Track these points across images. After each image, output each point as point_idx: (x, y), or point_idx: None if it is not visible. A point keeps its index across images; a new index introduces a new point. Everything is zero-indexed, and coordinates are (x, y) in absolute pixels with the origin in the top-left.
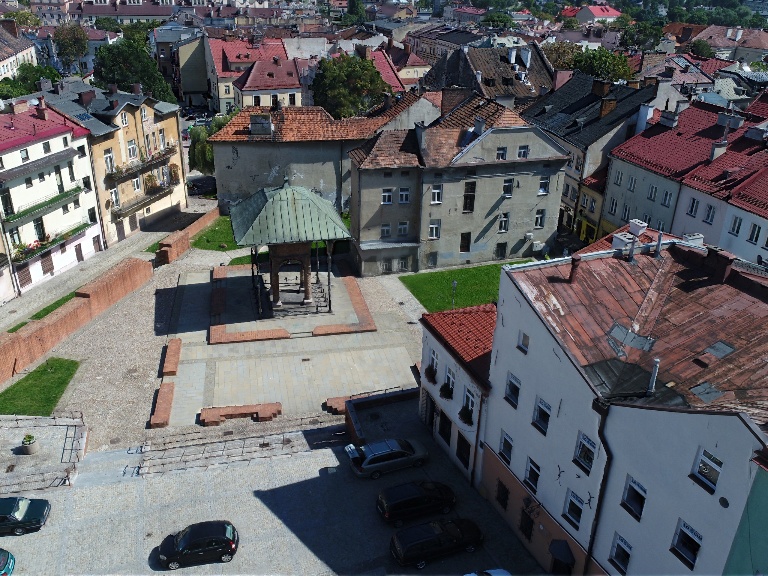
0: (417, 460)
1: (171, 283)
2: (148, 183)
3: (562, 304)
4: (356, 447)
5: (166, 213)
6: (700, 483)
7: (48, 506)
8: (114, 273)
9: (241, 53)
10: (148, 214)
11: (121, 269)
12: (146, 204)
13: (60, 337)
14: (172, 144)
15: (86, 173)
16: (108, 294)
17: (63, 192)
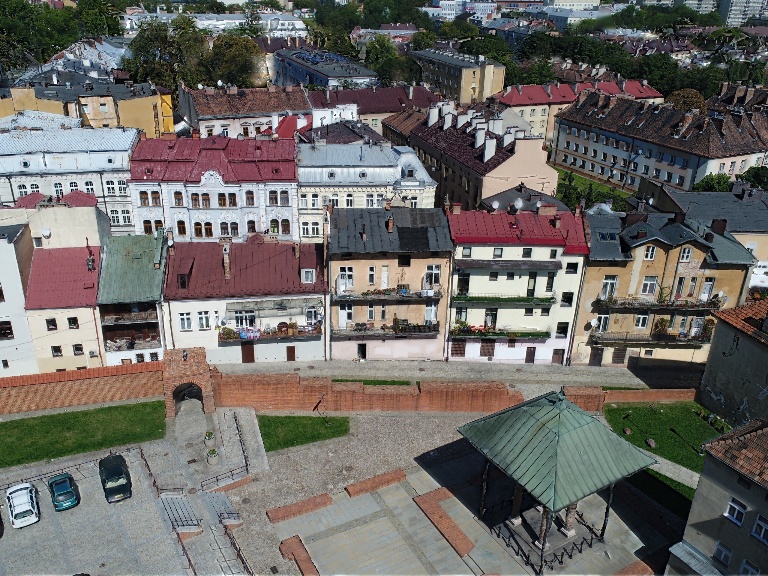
0: None
1: None
2: (660, 326)
3: None
4: None
5: (679, 365)
6: None
7: (127, 495)
8: (467, 386)
9: None
10: (648, 356)
11: (477, 387)
12: (647, 345)
13: (374, 407)
14: (719, 298)
15: (571, 289)
16: (447, 400)
17: (533, 296)
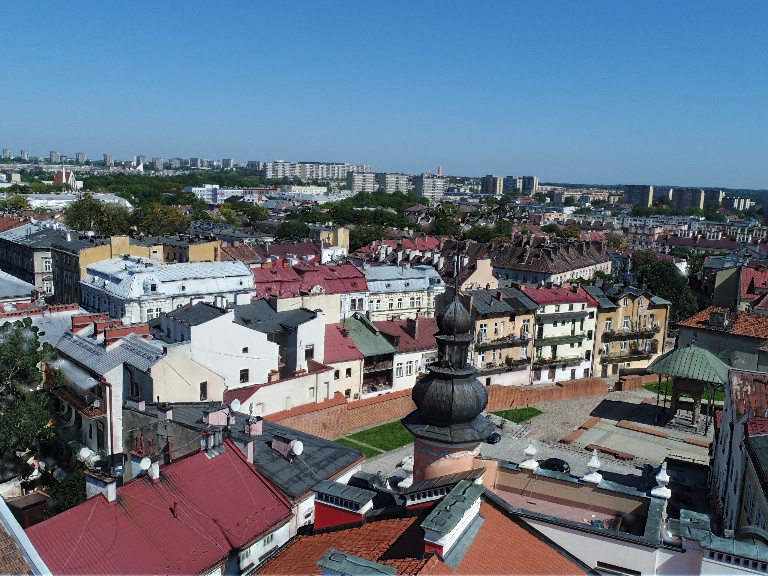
0: (685, 486)
1: (616, 399)
2: (633, 347)
3: (753, 390)
4: None
5: (642, 371)
6: (741, 447)
7: (500, 438)
8: (582, 380)
9: (767, 281)
10: (628, 367)
11: (587, 380)
12: (628, 360)
13: (540, 400)
14: (658, 326)
15: (591, 328)
16: (574, 390)
17: (574, 335)
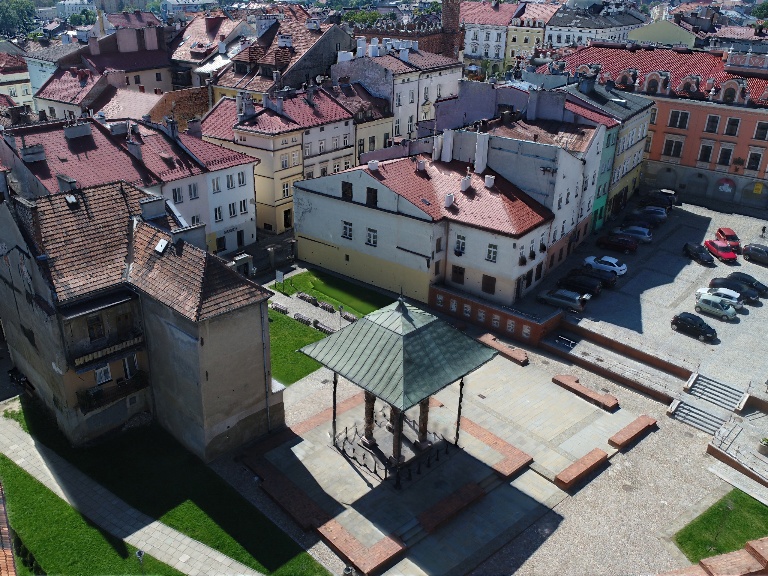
0: None
1: None
2: None
3: None
4: (584, 295)
5: None
6: None
7: None
8: None
9: None
10: None
11: None
12: None
13: None
14: None
15: None
16: None
17: None
